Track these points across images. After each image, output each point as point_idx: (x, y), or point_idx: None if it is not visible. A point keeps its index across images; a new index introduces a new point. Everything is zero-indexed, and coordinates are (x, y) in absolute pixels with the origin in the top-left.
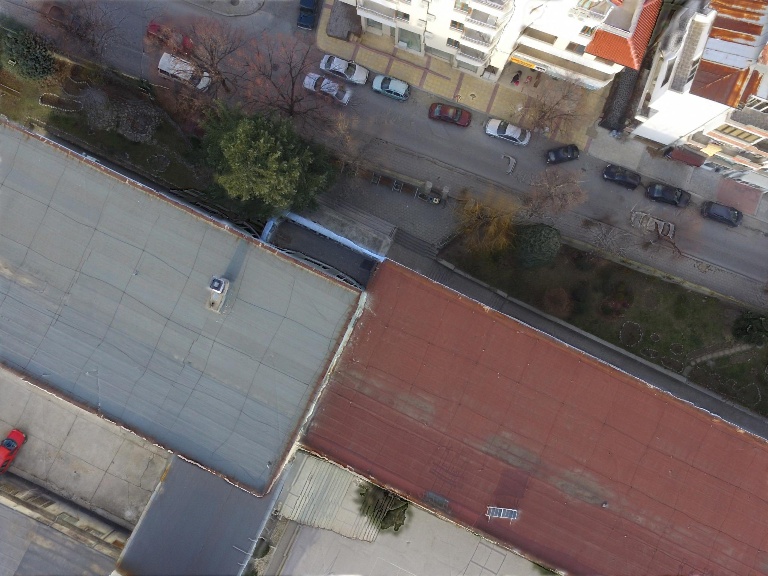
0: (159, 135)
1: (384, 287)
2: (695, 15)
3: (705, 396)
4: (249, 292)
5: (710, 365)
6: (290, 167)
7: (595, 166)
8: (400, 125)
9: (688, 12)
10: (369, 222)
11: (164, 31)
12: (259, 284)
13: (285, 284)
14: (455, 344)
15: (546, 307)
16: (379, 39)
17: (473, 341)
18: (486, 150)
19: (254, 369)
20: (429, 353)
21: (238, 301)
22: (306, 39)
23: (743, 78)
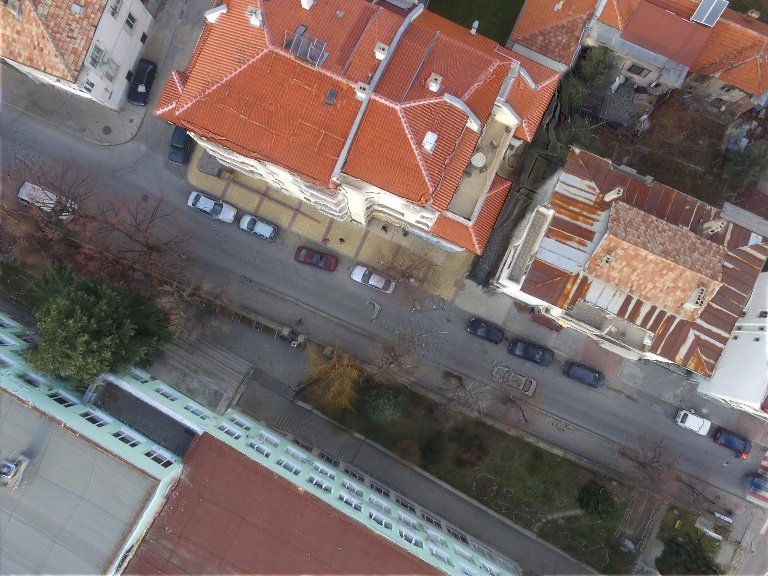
0: (22, 256)
1: (203, 458)
2: (538, 207)
3: (555, 553)
4: (49, 470)
5: (561, 523)
6: (100, 348)
7: (460, 318)
8: (266, 264)
9: (532, 204)
10: (226, 360)
11: (32, 156)
12: (60, 463)
13: (85, 465)
14: (268, 522)
15: (402, 453)
16: (251, 177)
17: (287, 520)
18: (351, 295)
19: (48, 548)
20: (242, 529)
21: (38, 478)
22: (177, 172)
23: (573, 282)
